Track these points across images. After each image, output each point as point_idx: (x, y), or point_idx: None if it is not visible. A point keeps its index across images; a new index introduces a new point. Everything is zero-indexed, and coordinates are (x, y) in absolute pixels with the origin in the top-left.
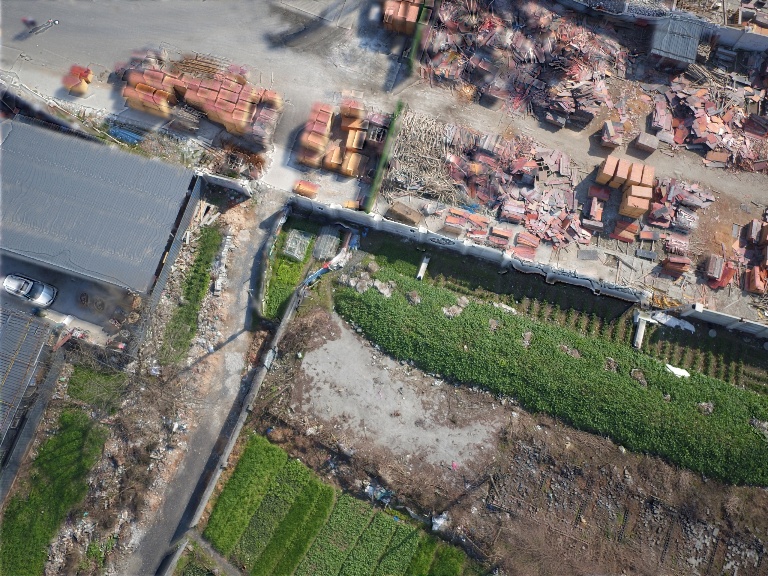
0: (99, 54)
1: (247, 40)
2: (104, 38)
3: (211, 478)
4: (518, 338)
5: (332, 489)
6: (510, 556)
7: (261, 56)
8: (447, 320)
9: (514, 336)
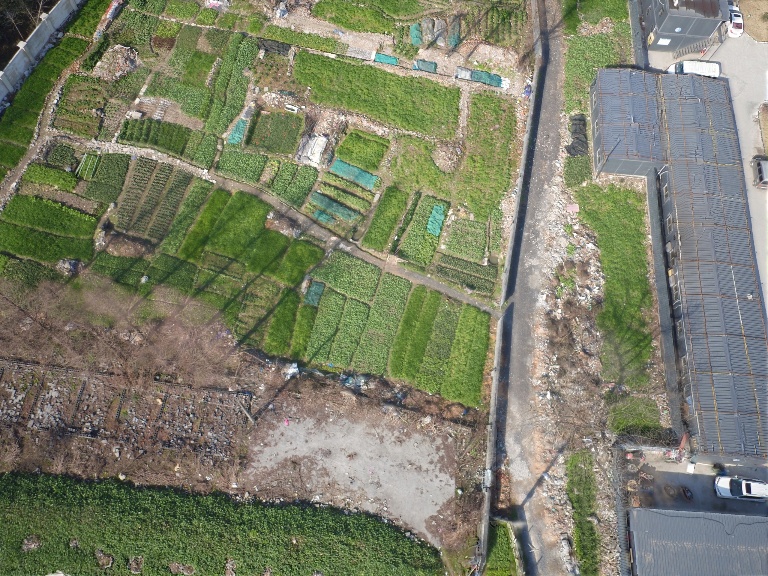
0: None
1: None
2: None
3: None
4: (239, 568)
5: (393, 376)
6: (224, 357)
7: None
8: (319, 568)
9: (244, 569)
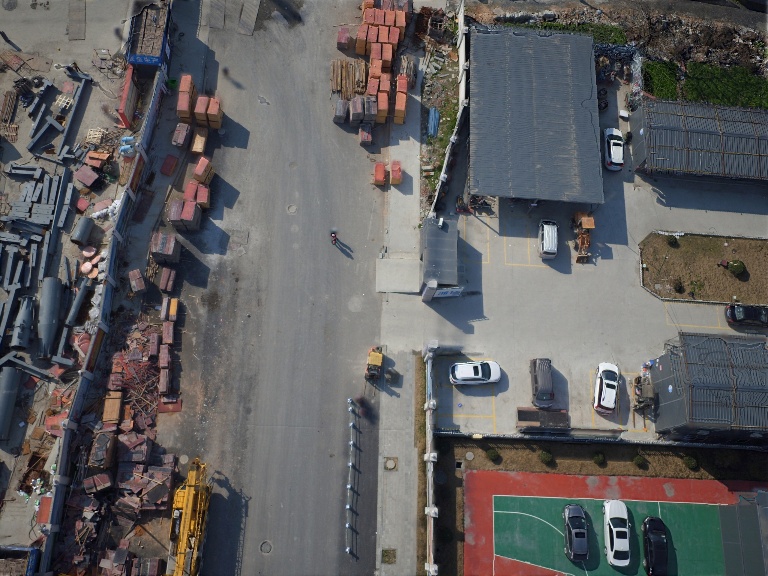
0: (358, 183)
1: (304, 55)
2: (338, 184)
3: None
4: None
5: None
6: None
7: (319, 39)
8: None
9: None
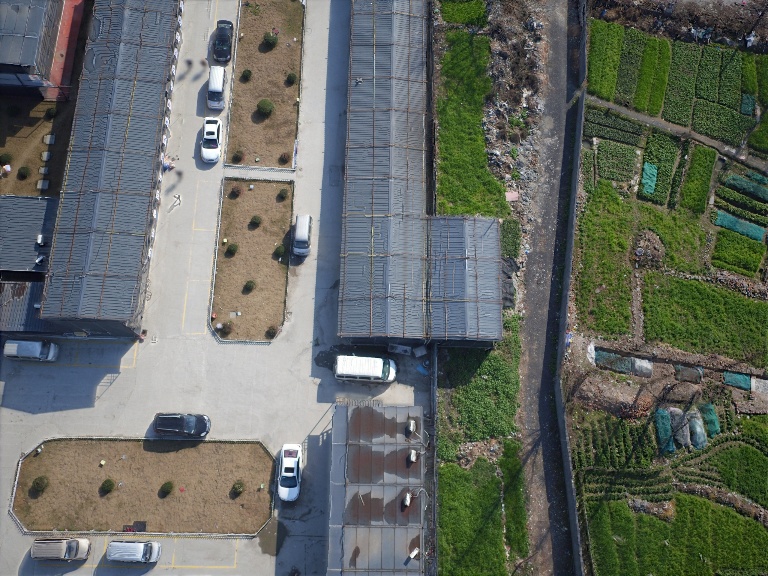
0: None
1: None
2: None
3: (585, 42)
4: None
5: (666, 40)
6: None
7: None
8: None
9: None
